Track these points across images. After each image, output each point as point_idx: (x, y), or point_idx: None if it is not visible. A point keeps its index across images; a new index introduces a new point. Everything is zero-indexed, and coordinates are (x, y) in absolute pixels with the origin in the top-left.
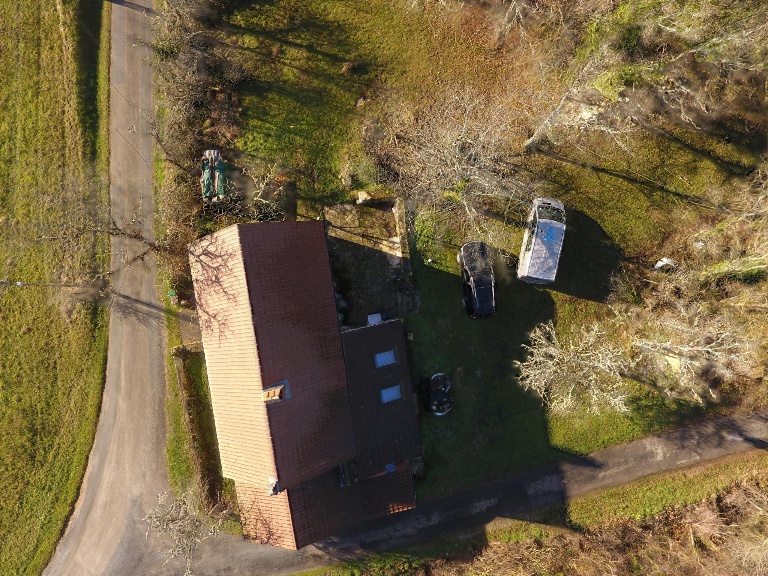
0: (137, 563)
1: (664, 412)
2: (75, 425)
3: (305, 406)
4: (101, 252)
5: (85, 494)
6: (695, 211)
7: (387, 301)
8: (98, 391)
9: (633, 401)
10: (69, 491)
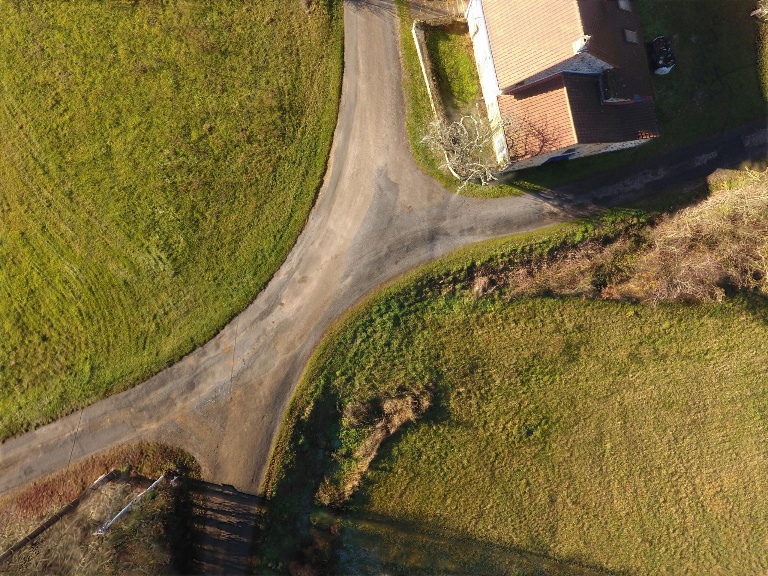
0: (387, 225)
1: None
2: (319, 106)
3: None
4: None
5: (333, 167)
6: None
7: None
8: (338, 75)
9: None
10: (318, 165)
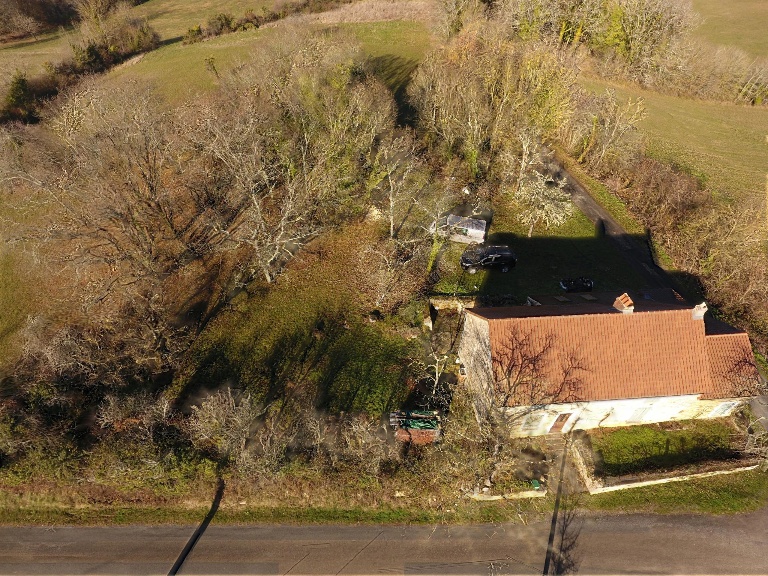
0: None
1: None
2: None
3: None
4: None
5: None
6: (434, 180)
7: None
8: None
9: None
10: None
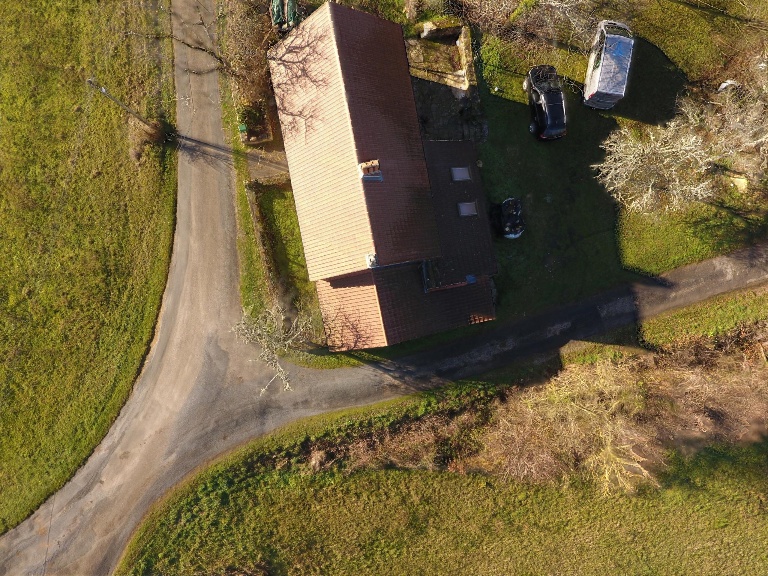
0: (215, 398)
1: (732, 231)
2: (148, 266)
3: (395, 193)
4: (166, 98)
5: (160, 333)
6: (756, 34)
7: (453, 135)
8: (169, 232)
9: (701, 221)
10: (144, 331)
